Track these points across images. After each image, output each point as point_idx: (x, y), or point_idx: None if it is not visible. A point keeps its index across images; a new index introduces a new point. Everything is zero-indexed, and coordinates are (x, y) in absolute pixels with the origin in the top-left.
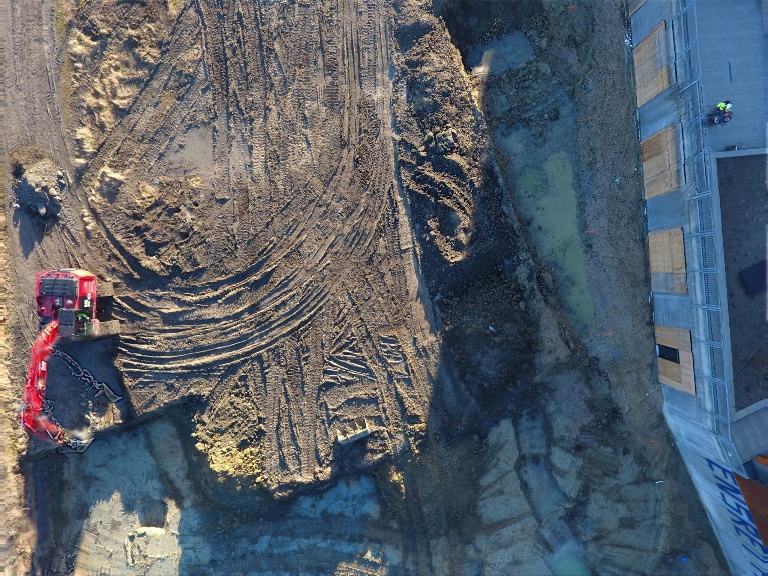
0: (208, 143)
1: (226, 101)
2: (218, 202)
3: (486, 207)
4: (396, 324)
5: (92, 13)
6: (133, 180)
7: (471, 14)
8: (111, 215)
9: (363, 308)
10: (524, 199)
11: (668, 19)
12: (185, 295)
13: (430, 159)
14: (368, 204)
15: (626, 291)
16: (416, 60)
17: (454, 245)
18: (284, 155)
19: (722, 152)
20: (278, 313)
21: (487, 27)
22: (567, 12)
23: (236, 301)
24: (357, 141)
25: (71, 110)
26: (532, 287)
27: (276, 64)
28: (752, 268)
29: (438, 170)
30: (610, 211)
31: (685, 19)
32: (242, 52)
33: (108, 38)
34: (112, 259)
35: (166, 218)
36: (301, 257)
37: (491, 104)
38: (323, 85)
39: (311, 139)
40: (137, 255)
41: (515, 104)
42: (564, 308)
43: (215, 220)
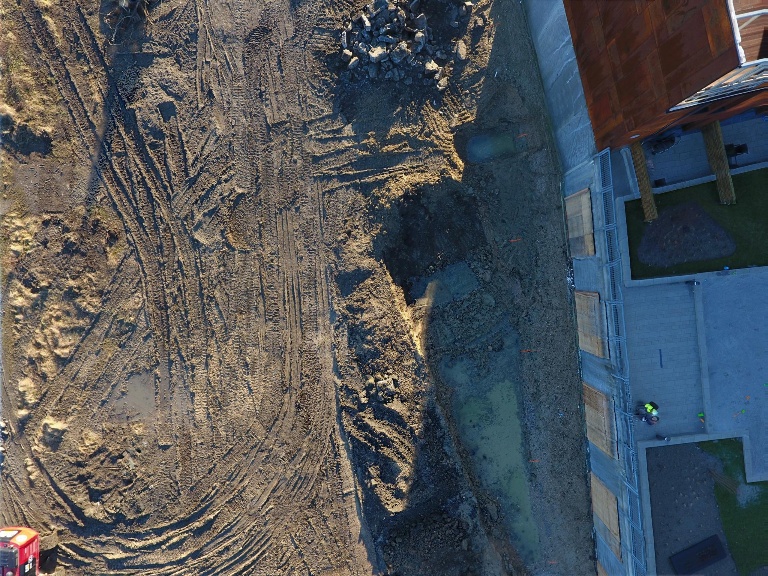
0: (150, 389)
1: (167, 348)
2: (161, 448)
3: (427, 454)
4: (339, 566)
5: (32, 266)
6: (76, 427)
7: (414, 247)
8: (55, 463)
9: (306, 551)
10: (469, 429)
11: (601, 295)
12: (129, 540)
13: (371, 405)
14: (310, 449)
15: (570, 524)
16: (356, 307)
17: (395, 493)
18: (226, 401)
19: (652, 442)
20: (221, 558)
21: (430, 261)
22: (511, 245)
23: (180, 547)
24: (299, 386)
25: (13, 361)
26: (475, 523)
27: (217, 311)
28: (682, 553)
29: (379, 417)
30: (554, 444)
31: (615, 310)
32: (183, 300)
33: (48, 289)
34: (56, 507)
35: (109, 465)
36: (244, 502)
37: (435, 336)
38: (264, 330)
39: (253, 385)
40: (80, 504)
41: (459, 336)
42: (509, 536)
43: (158, 466)
